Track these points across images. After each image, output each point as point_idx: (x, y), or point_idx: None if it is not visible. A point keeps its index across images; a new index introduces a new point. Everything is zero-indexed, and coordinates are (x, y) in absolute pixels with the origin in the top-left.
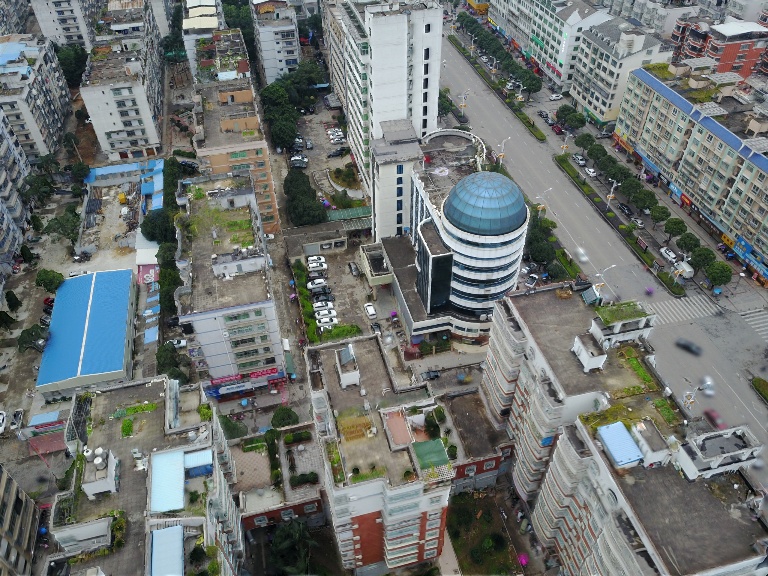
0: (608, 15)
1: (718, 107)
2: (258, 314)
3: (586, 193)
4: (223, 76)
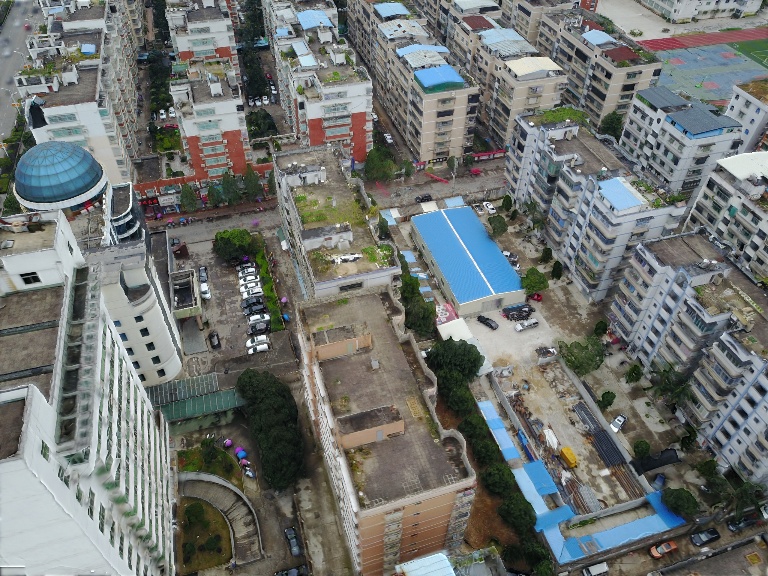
0: None
1: None
2: None
3: None
4: (439, 567)
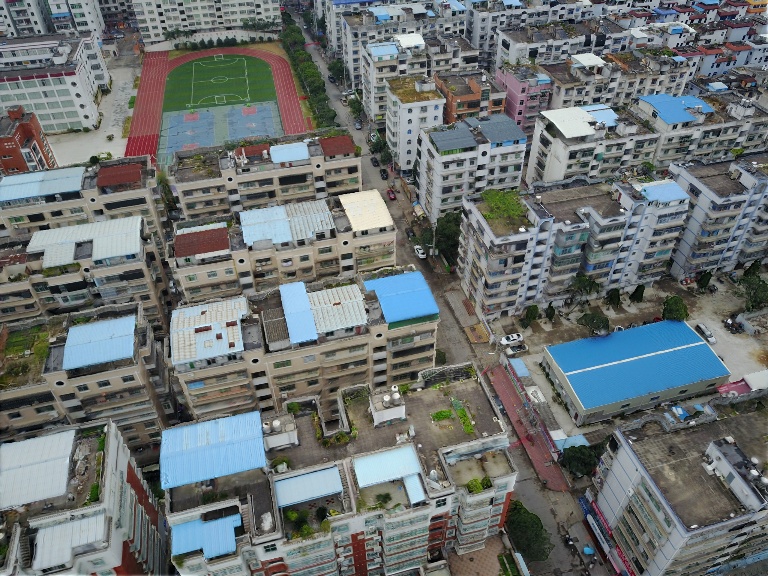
0: None
1: None
2: (668, 522)
3: None
4: None
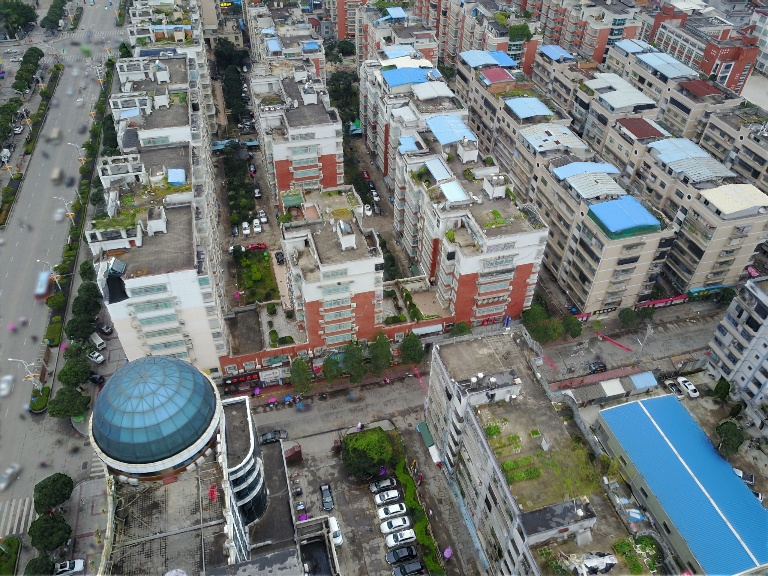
0: None
1: None
2: None
3: None
4: None
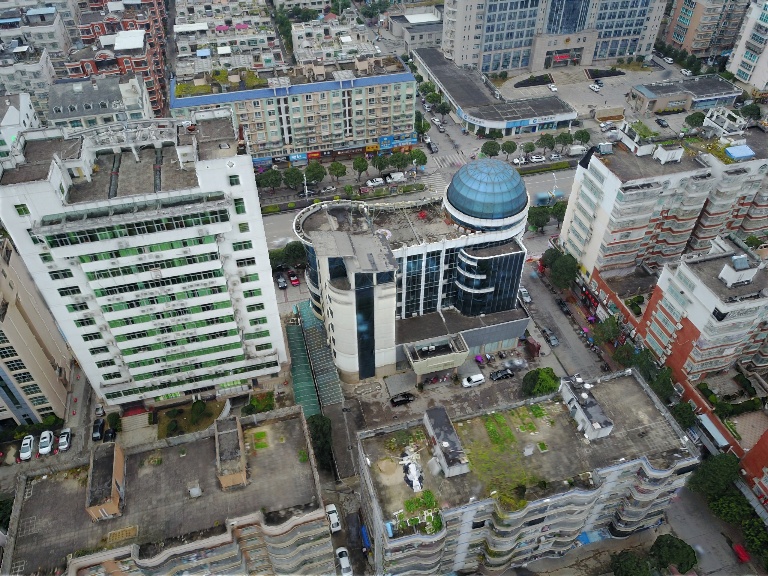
0: (26, 94)
1: (278, 78)
2: None
3: (277, 211)
4: None
